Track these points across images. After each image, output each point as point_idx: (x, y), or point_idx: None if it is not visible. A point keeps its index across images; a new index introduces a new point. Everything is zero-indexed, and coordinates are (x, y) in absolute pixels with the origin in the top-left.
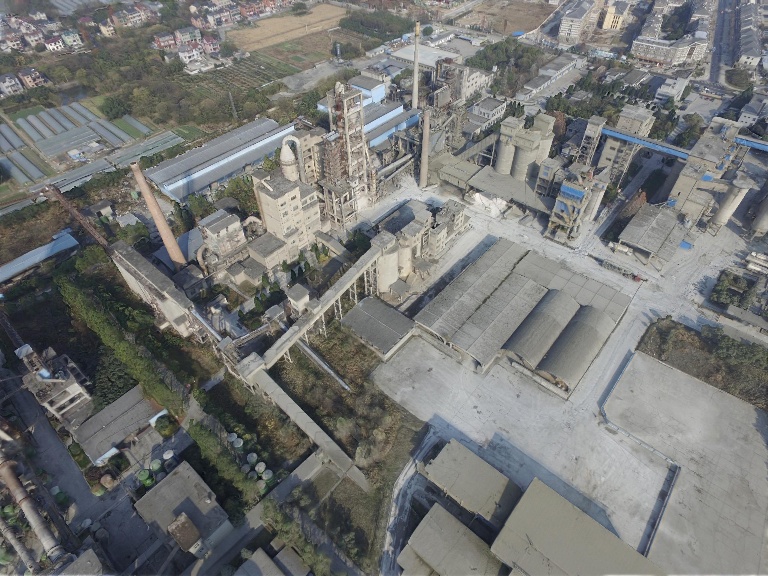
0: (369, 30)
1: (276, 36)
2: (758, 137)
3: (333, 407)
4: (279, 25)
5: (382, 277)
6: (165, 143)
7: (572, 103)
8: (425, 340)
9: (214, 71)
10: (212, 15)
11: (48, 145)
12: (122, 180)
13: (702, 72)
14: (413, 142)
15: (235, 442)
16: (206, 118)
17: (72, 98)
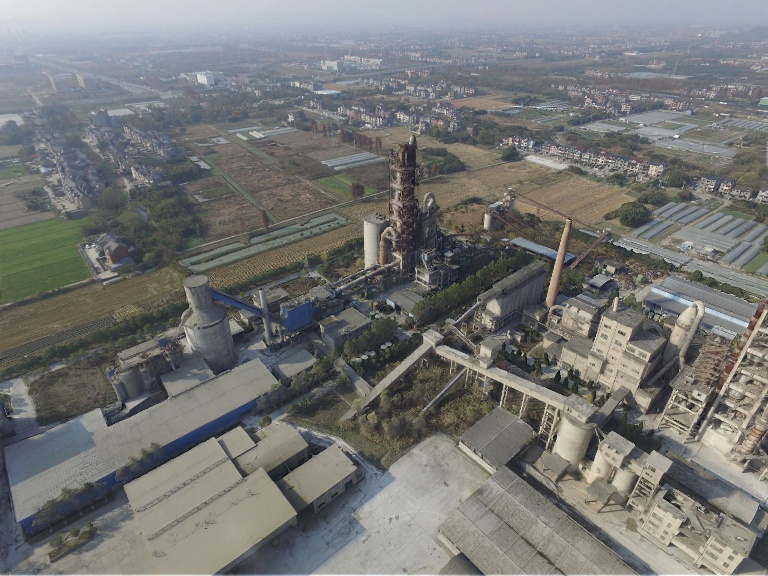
0: None
1: None
2: None
3: None
4: None
5: None
6: (748, 285)
7: None
8: None
9: None
10: None
11: (692, 232)
12: (661, 270)
13: None
14: None
15: (384, 345)
16: None
17: None
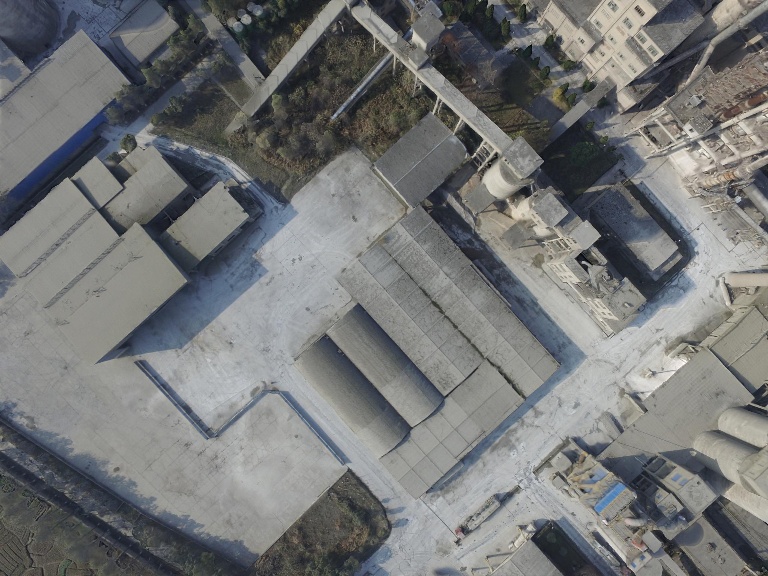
0: None
1: None
2: None
3: None
4: None
5: None
6: None
7: None
8: (398, 221)
9: None
10: None
11: None
12: None
13: None
14: None
15: None
16: None
17: None
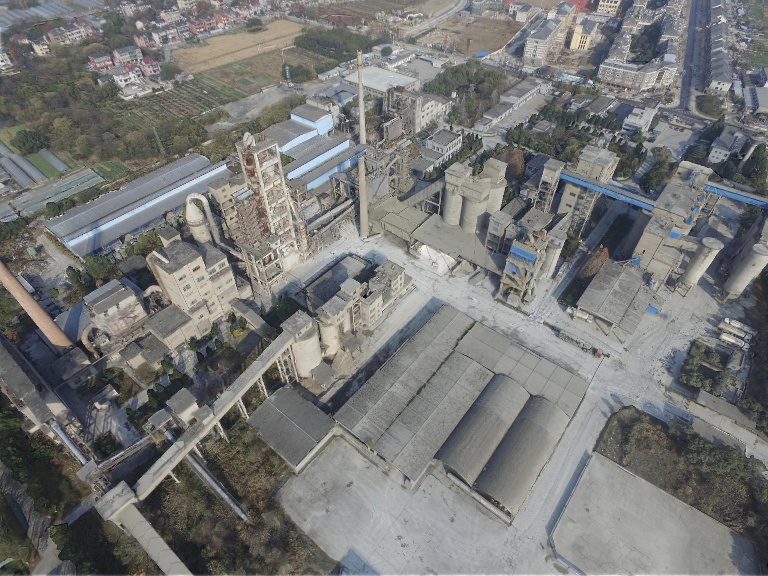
0: (325, 49)
1: (225, 56)
2: (729, 185)
3: (223, 546)
4: (230, 43)
5: (300, 362)
6: (81, 183)
7: (534, 135)
8: (348, 442)
9: (151, 96)
10: (157, 32)
11: None
12: (22, 231)
13: (672, 98)
14: (354, 186)
15: None
16: (132, 153)
17: None
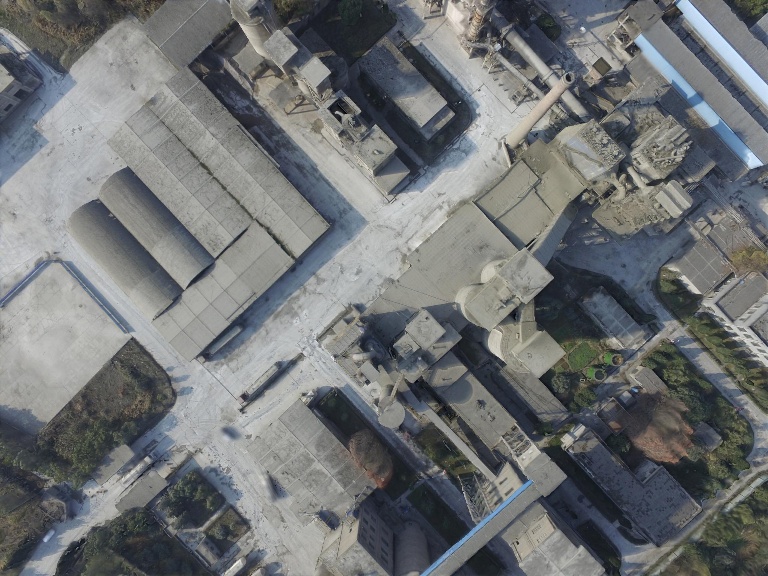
0: None
1: None
2: None
3: None
4: None
5: None
6: None
7: None
8: None
9: None
10: None
11: None
12: None
13: None
14: None
15: None
16: None
17: None
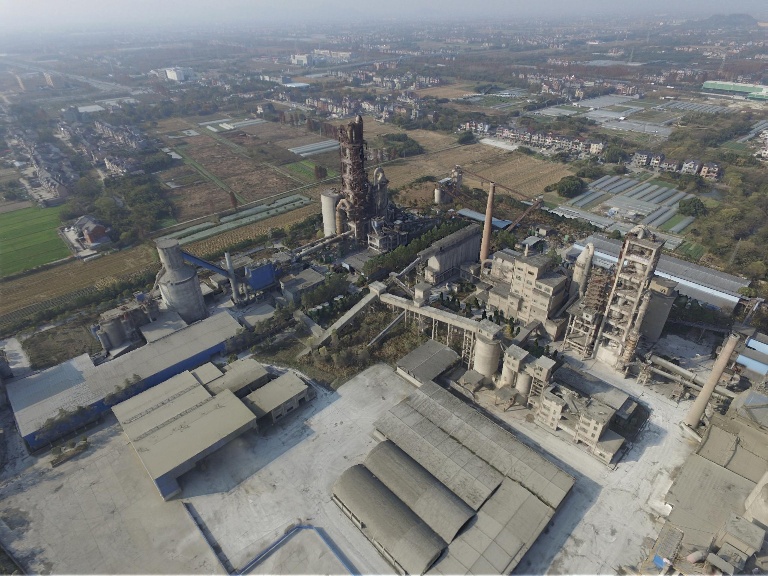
0: None
1: None
2: None
3: None
4: None
5: None
6: None
7: None
8: None
9: None
10: None
11: (620, 200)
12: (586, 231)
13: None
14: None
15: (337, 297)
16: (721, 251)
17: (698, 191)
